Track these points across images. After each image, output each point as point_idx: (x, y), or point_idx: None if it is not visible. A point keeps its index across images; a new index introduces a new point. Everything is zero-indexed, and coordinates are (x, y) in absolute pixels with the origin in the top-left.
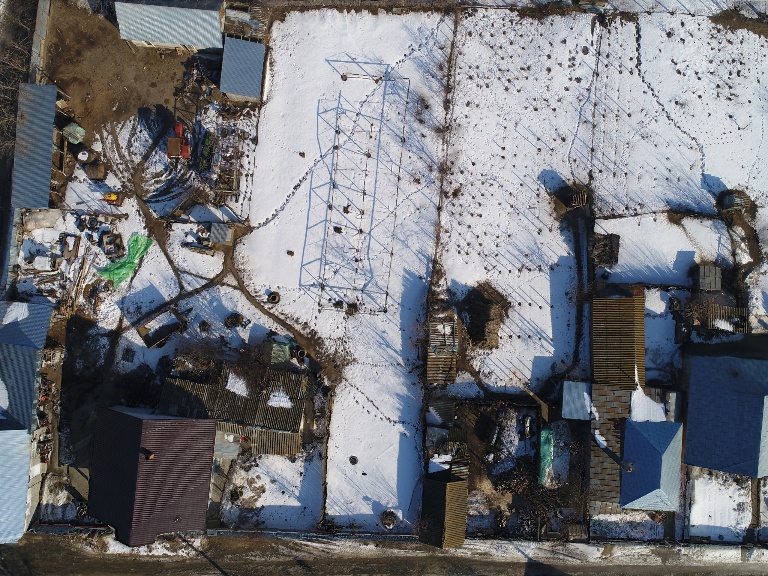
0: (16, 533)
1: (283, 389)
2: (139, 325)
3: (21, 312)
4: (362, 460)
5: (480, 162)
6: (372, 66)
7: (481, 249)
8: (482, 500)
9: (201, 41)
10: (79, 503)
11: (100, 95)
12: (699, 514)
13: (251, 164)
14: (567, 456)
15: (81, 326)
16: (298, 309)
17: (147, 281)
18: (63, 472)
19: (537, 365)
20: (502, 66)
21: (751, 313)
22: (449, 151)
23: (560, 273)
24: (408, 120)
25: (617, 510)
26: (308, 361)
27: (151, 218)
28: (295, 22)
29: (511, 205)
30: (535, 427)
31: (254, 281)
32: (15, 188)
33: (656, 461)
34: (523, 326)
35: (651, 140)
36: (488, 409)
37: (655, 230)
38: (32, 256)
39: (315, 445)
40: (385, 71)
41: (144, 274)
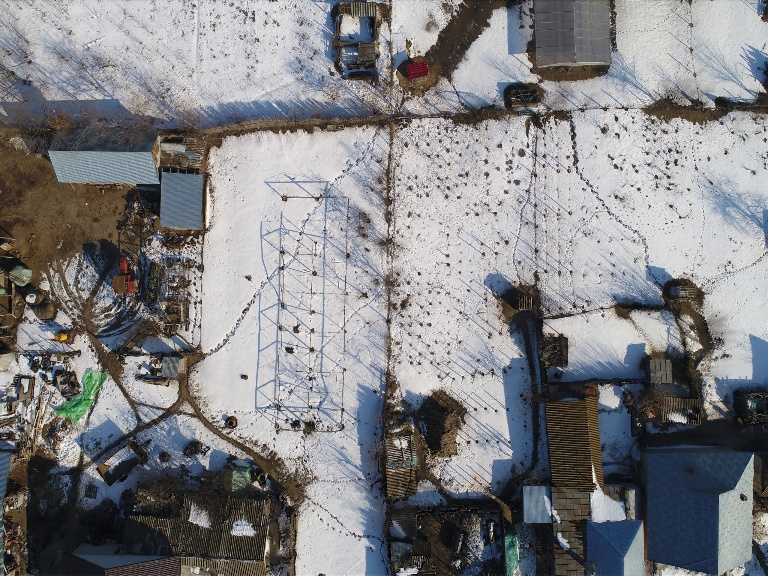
0: None
1: (245, 517)
2: (99, 461)
3: None
4: None
5: (426, 271)
6: (311, 184)
7: (433, 358)
8: None
9: (138, 179)
10: None
11: (44, 234)
12: None
13: (199, 292)
14: (533, 556)
15: (42, 466)
16: (256, 432)
17: (104, 416)
18: None
19: (497, 469)
20: (440, 174)
21: (705, 400)
22: (394, 263)
23: (513, 375)
24: (351, 235)
25: None
26: (270, 483)
27: (104, 353)
28: (232, 147)
29: (460, 311)
30: (499, 530)
31: (210, 407)
32: None
33: (618, 563)
34: (480, 431)
35: (593, 236)
36: (452, 516)
37: (604, 326)
38: None
39: (283, 566)
40: (325, 188)
41: (101, 410)
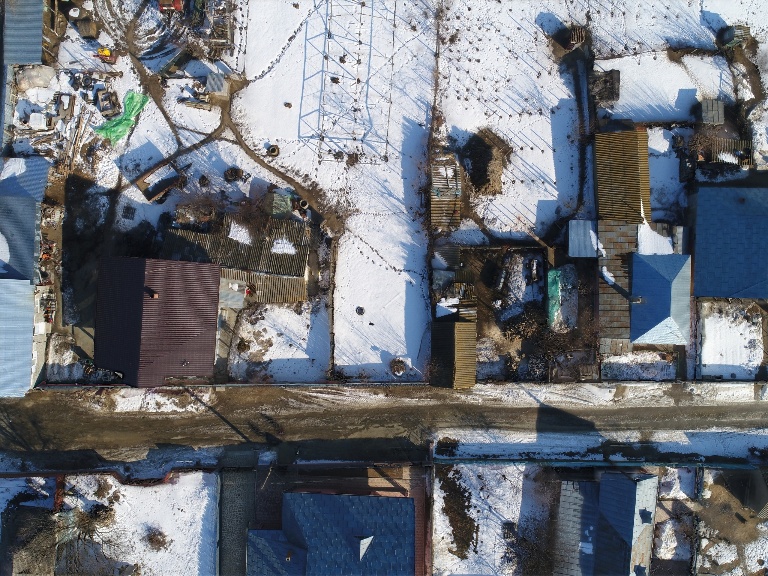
0: (23, 385)
1: (286, 236)
2: None
3: (18, 167)
4: (369, 310)
5: (476, 7)
6: None
7: (480, 94)
8: (491, 347)
9: None
10: (85, 360)
11: None
12: (710, 353)
13: (245, 17)
14: (575, 300)
15: (80, 185)
16: (298, 161)
17: (144, 138)
18: (68, 332)
19: (541, 209)
20: None
21: (755, 149)
22: None
23: (561, 116)
24: None
25: (628, 347)
26: (310, 213)
27: (146, 75)
28: None
29: (509, 50)
30: (542, 271)
31: (252, 135)
32: (7, 45)
33: (665, 290)
34: (526, 171)
35: None
36: (494, 255)
37: (655, 68)
38: (27, 116)
39: (321, 297)
40: None
41: (141, 131)
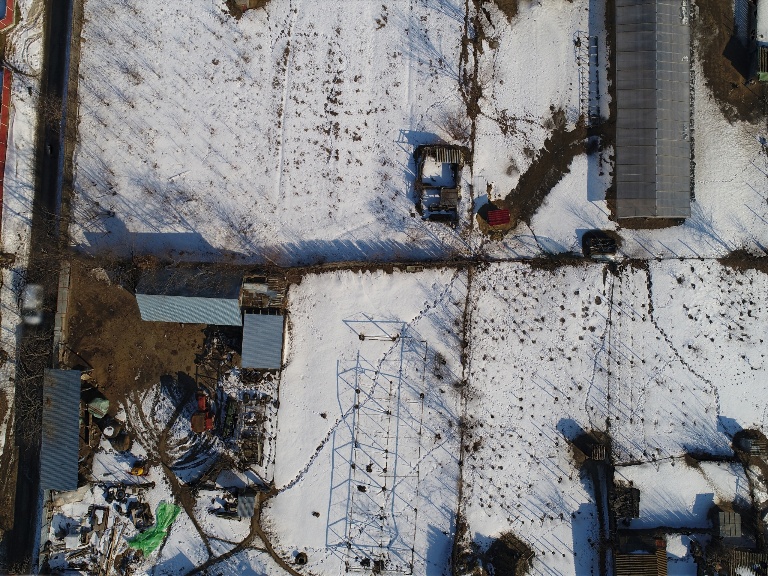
0: None
1: None
2: None
3: None
4: None
5: (499, 414)
6: (389, 324)
7: (503, 501)
8: None
9: (221, 321)
10: None
11: (122, 365)
12: None
13: (274, 428)
14: None
15: None
16: (326, 569)
17: (176, 549)
18: None
19: None
20: (517, 318)
21: None
22: (468, 405)
23: (582, 521)
24: (426, 376)
25: None
26: None
27: (177, 485)
28: (311, 284)
29: (531, 455)
30: None
31: (281, 543)
32: (44, 471)
33: None
34: (547, 575)
35: (666, 385)
36: None
37: (674, 475)
38: (62, 531)
39: None
40: (402, 328)
41: (173, 542)
